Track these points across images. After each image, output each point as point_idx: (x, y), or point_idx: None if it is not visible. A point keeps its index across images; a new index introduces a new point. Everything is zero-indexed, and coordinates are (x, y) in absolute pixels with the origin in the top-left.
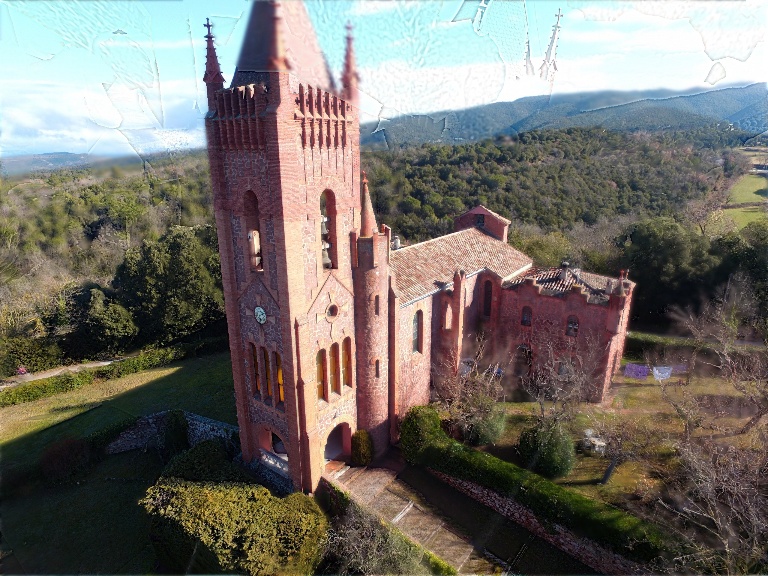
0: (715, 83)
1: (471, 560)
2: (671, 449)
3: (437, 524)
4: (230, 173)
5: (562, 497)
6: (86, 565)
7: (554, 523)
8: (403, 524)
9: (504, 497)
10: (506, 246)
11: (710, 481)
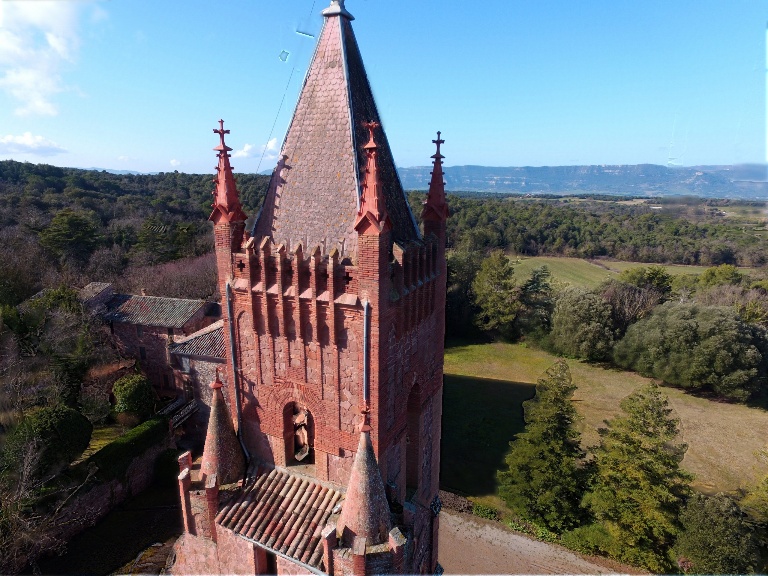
0: (185, 232)
1: None
2: None
3: None
4: None
5: None
6: None
7: None
8: None
9: None
10: None
11: None
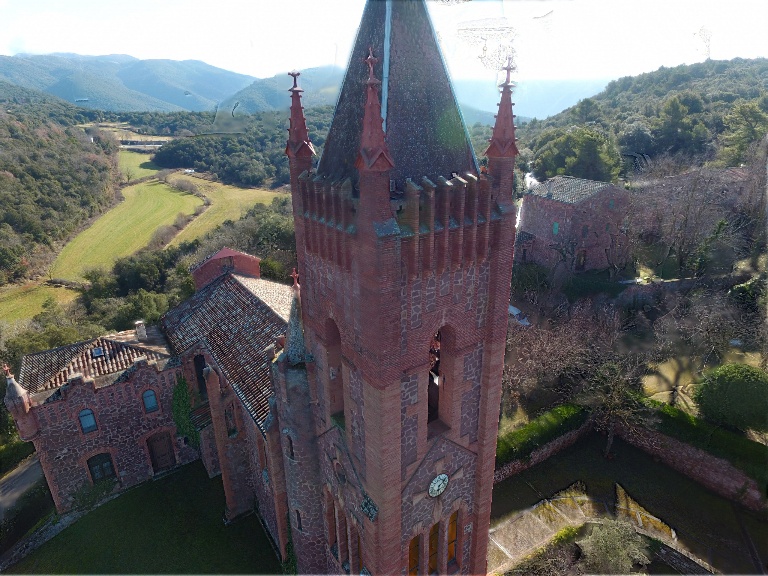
0: None
1: (541, 519)
2: (527, 366)
3: (510, 525)
4: (408, 315)
5: (528, 434)
6: None
7: (530, 453)
8: (510, 550)
9: (501, 468)
10: (268, 282)
11: (557, 368)
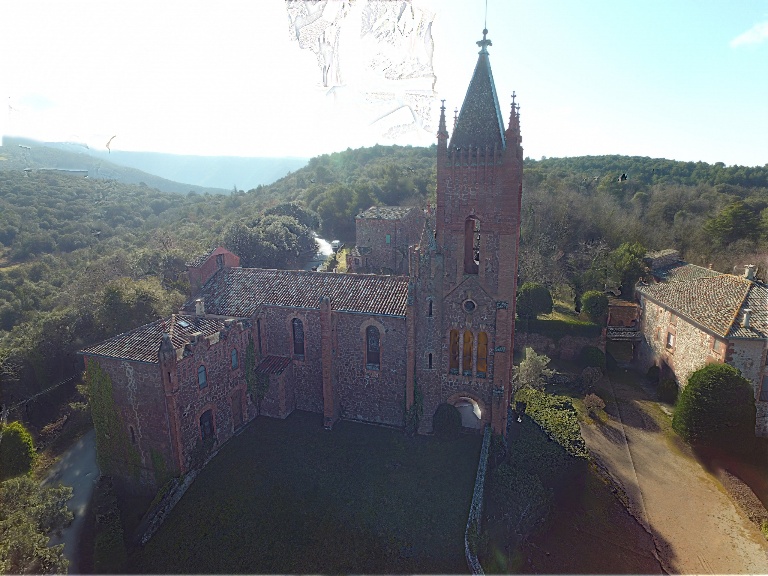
0: None
1: None
2: None
3: None
4: None
5: None
6: (625, 570)
7: None
8: None
9: None
10: None
11: None
